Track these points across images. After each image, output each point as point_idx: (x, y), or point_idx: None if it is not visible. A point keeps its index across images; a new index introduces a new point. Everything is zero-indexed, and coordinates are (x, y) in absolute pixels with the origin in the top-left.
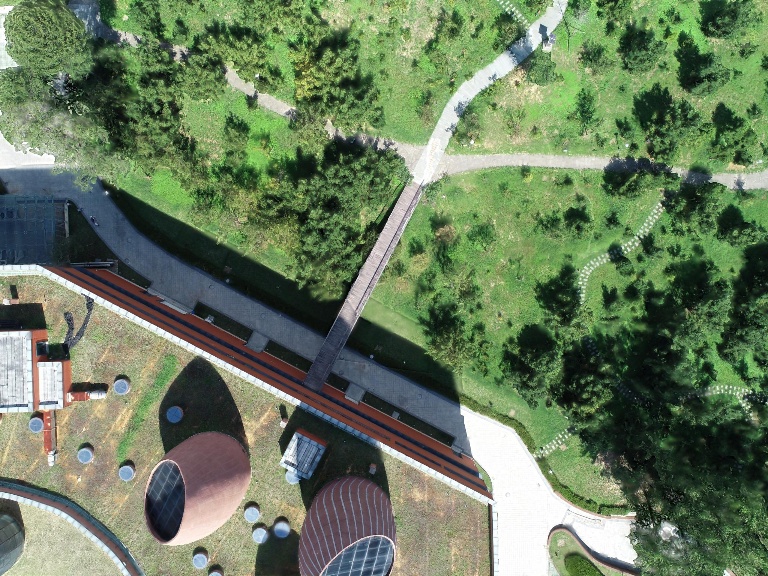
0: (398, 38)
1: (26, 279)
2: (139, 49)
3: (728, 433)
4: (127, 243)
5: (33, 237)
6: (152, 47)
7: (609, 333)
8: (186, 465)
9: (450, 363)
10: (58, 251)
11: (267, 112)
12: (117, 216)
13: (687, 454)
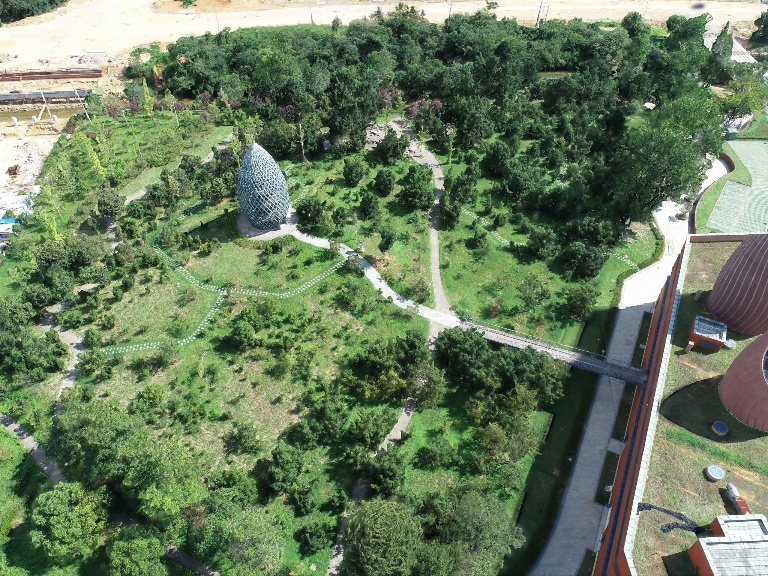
0: None
1: (641, 575)
2: None
3: None
4: None
5: None
6: None
7: None
8: (760, 351)
9: (594, 293)
10: None
11: (408, 431)
12: None
13: (607, 204)
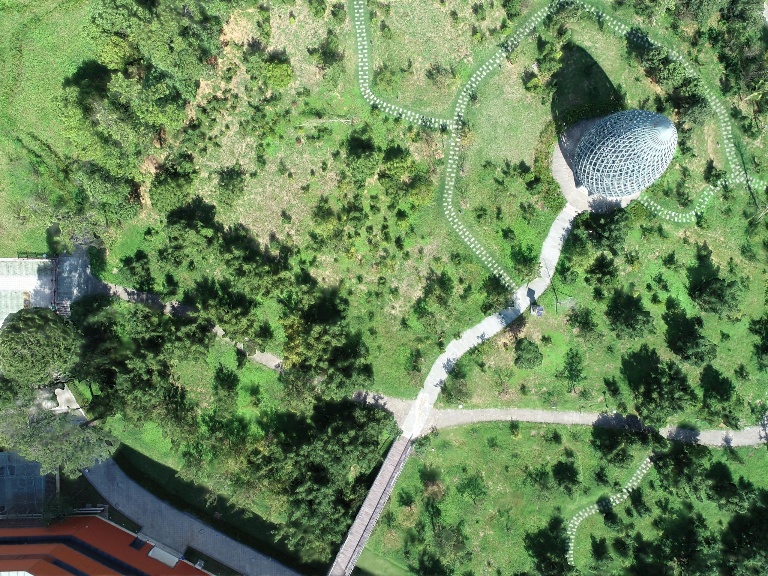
0: (387, 296)
1: None
2: (128, 318)
3: None
4: (117, 488)
5: (23, 494)
6: (141, 315)
7: None
8: None
9: None
10: (48, 514)
11: (257, 365)
12: (107, 461)
13: None
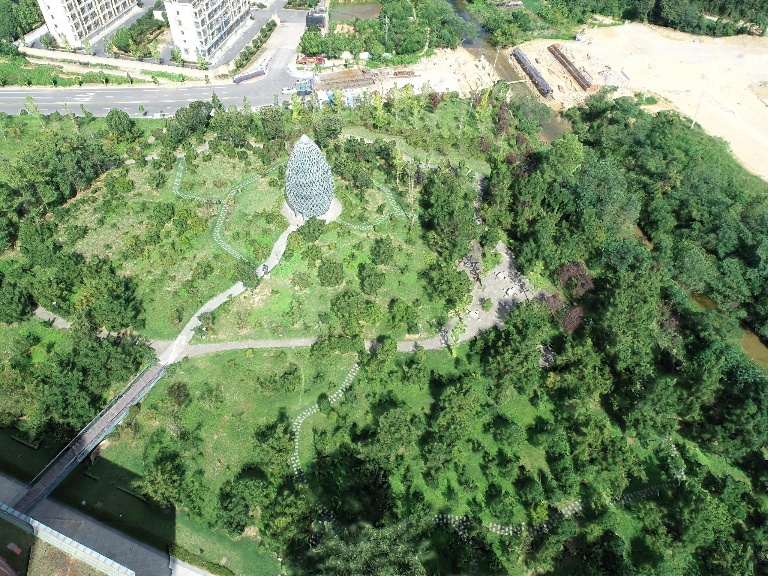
0: (166, 281)
1: None
2: None
3: (450, 564)
4: None
5: None
6: None
7: (321, 471)
8: None
9: (151, 488)
10: None
11: None
12: None
13: None
